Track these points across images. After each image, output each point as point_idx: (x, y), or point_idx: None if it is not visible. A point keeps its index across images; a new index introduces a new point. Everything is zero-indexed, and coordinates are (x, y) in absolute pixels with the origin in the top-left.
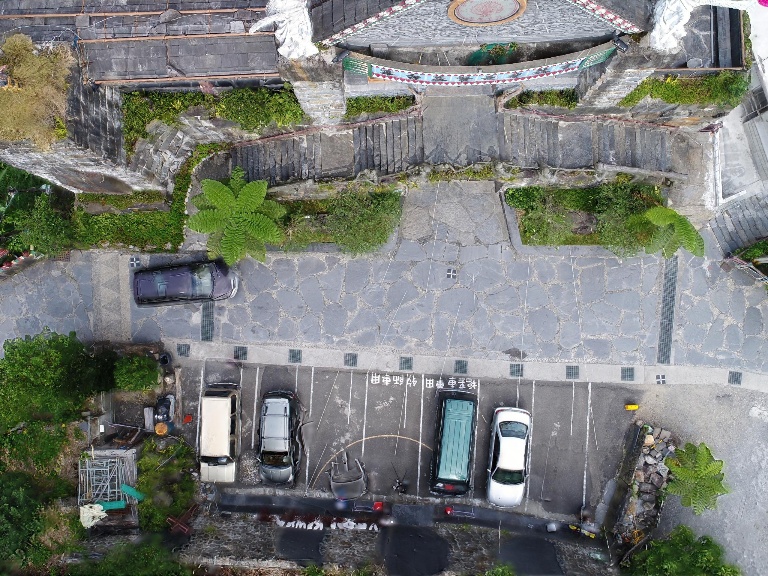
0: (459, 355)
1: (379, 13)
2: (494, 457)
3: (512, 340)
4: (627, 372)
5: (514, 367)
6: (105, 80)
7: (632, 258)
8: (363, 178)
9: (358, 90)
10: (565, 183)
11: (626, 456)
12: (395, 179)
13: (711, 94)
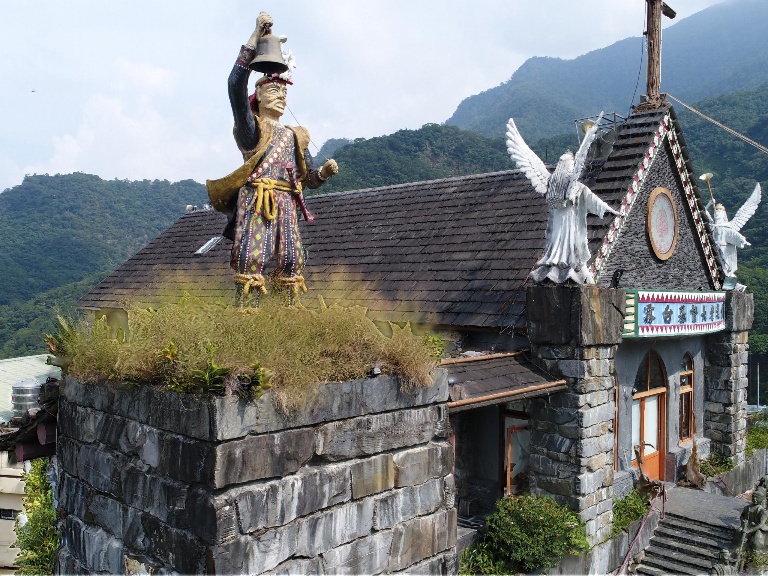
0: None
1: (621, 207)
2: None
3: None
4: None
5: None
6: None
7: None
8: None
9: None
10: None
11: None
12: (746, 570)
13: (767, 433)
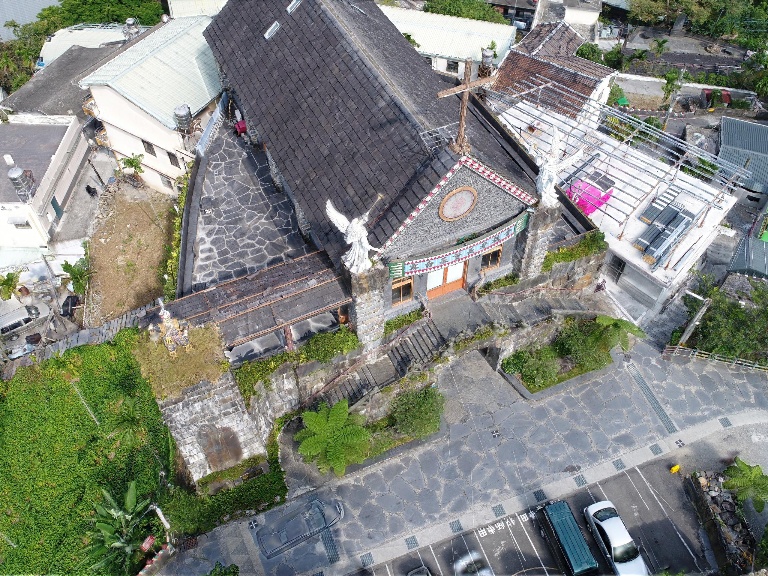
0: (534, 488)
1: (406, 221)
2: (605, 544)
3: (564, 461)
4: (655, 448)
5: (577, 479)
6: (236, 342)
7: (606, 376)
8: (411, 371)
9: (387, 314)
10: (537, 340)
11: (697, 506)
12: (432, 363)
13: (588, 248)
